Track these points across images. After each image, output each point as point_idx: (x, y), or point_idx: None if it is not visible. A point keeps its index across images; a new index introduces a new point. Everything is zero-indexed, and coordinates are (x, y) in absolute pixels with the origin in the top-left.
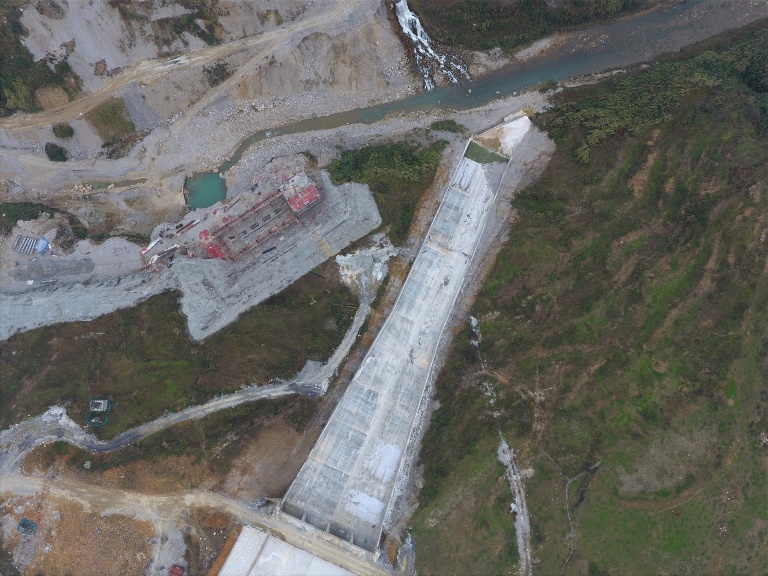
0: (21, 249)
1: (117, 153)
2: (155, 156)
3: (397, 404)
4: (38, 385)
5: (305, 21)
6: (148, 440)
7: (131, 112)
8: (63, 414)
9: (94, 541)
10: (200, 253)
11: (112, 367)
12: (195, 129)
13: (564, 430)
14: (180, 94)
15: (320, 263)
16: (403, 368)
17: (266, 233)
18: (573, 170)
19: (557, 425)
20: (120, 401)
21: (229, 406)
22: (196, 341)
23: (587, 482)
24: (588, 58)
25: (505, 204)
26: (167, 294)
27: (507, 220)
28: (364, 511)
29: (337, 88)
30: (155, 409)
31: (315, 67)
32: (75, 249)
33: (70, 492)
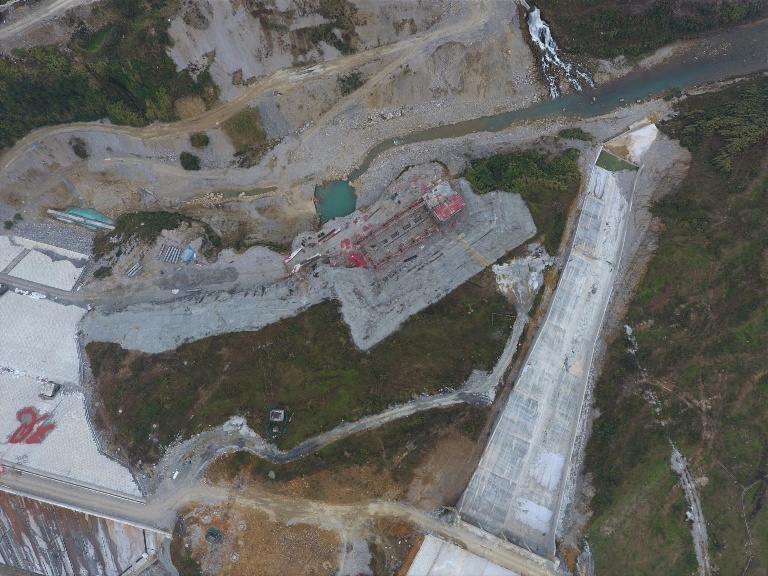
0: (166, 258)
1: (248, 162)
2: (286, 165)
3: (556, 412)
4: (215, 395)
5: (440, 30)
6: (327, 450)
7: (265, 121)
8: (243, 424)
9: (280, 550)
10: (342, 262)
11: (283, 377)
12: (325, 138)
13: (734, 438)
14: (313, 103)
15: (477, 272)
16: (559, 376)
17: (409, 242)
18: (714, 178)
19: (727, 434)
20: (295, 411)
21: (403, 415)
22: (363, 351)
23: (763, 490)
24: (710, 66)
25: (643, 212)
26: (327, 304)
27: (650, 228)
28: (533, 519)
29: (465, 96)
30: (330, 419)
31: (445, 76)
32: (218, 258)
33: (256, 502)
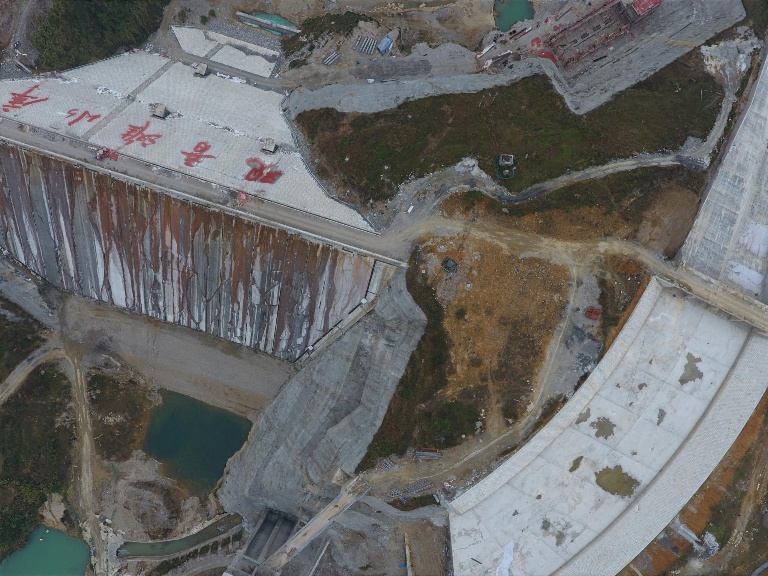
0: (362, 48)
1: None
2: None
3: (762, 190)
4: (445, 141)
5: None
6: (554, 194)
7: None
8: (475, 166)
9: (513, 281)
10: None
11: (504, 133)
12: None
13: None
14: None
15: (685, 53)
16: (763, 158)
17: (603, 39)
18: None
19: None
20: (521, 160)
21: (625, 169)
22: (579, 115)
23: None
24: None
25: None
26: (538, 76)
27: None
28: (745, 280)
29: None
30: (554, 169)
31: None
32: (412, 51)
33: (490, 235)
